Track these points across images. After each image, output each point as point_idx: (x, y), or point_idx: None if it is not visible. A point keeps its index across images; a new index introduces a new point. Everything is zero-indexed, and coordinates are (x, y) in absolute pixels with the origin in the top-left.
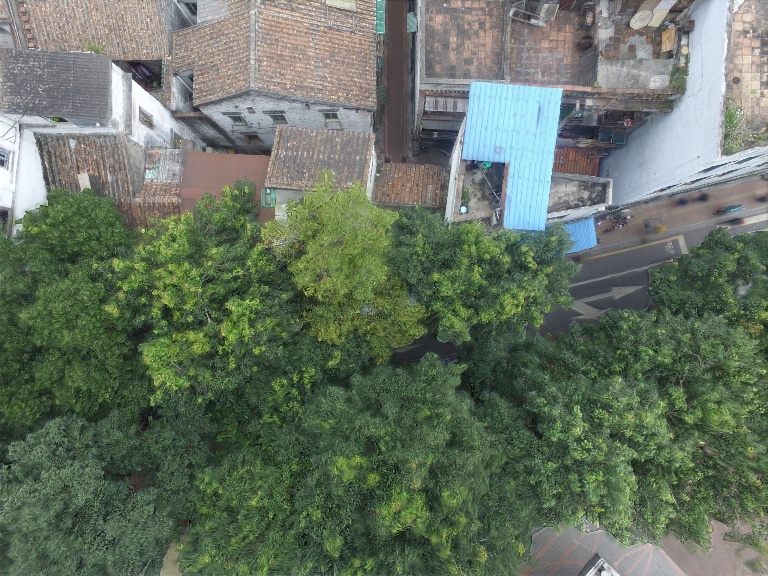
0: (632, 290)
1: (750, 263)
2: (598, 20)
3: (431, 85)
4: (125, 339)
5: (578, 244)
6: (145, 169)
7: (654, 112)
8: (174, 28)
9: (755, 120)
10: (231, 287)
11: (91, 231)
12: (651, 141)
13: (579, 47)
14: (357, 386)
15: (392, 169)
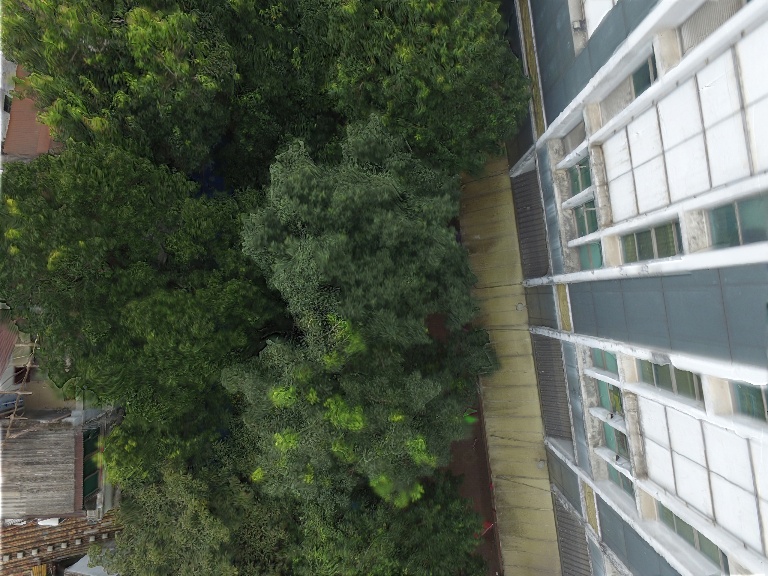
0: None
1: None
2: None
3: None
4: None
5: None
6: None
7: None
8: None
9: None
10: None
11: None
12: None
13: None
14: None
15: None
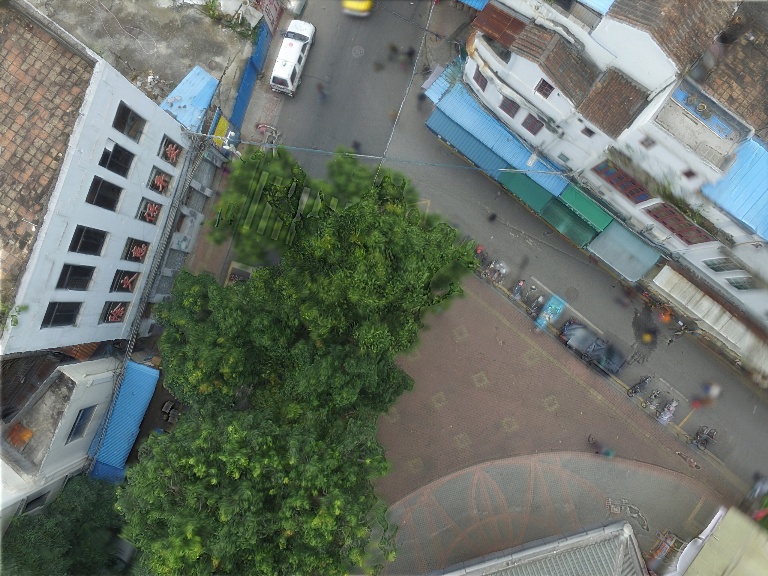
0: None
1: (177, 326)
2: None
3: None
4: None
5: (147, 389)
6: None
7: None
8: None
9: (13, 273)
10: None
11: None
12: None
13: None
14: None
15: None
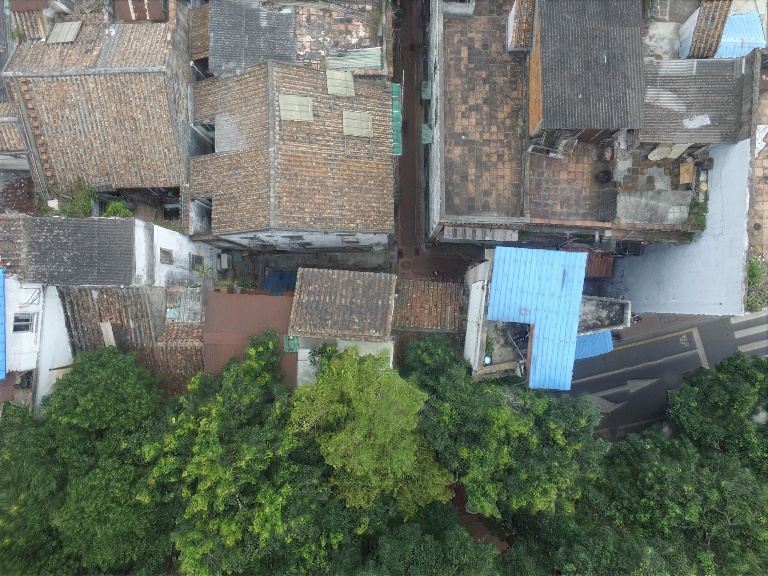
0: (647, 383)
1: None
2: (617, 155)
3: (451, 220)
4: (153, 508)
5: (594, 349)
6: (166, 308)
7: (673, 243)
8: (191, 152)
9: None
10: (261, 469)
11: (119, 407)
12: (669, 263)
13: (598, 180)
14: (387, 558)
15: (410, 288)
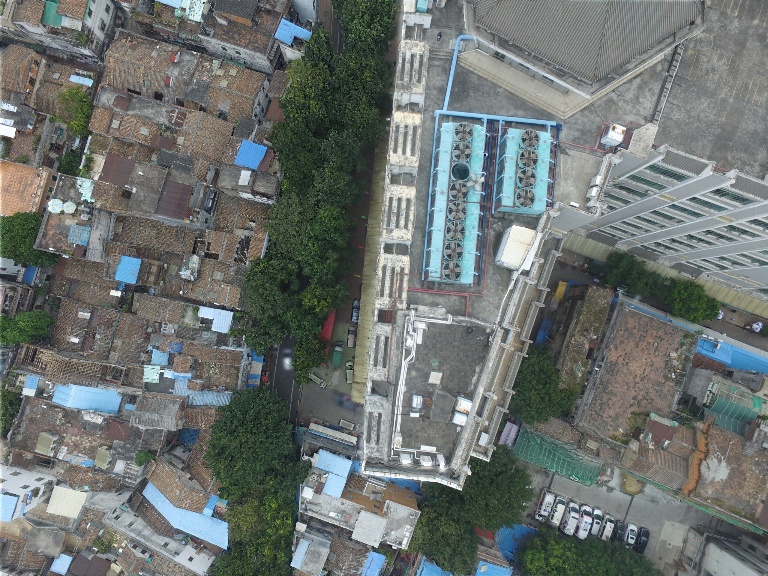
0: None
1: None
2: (264, 7)
3: None
4: None
5: None
6: None
7: (292, 1)
8: None
9: None
10: None
11: None
12: (299, 5)
13: (269, 14)
14: None
15: None
